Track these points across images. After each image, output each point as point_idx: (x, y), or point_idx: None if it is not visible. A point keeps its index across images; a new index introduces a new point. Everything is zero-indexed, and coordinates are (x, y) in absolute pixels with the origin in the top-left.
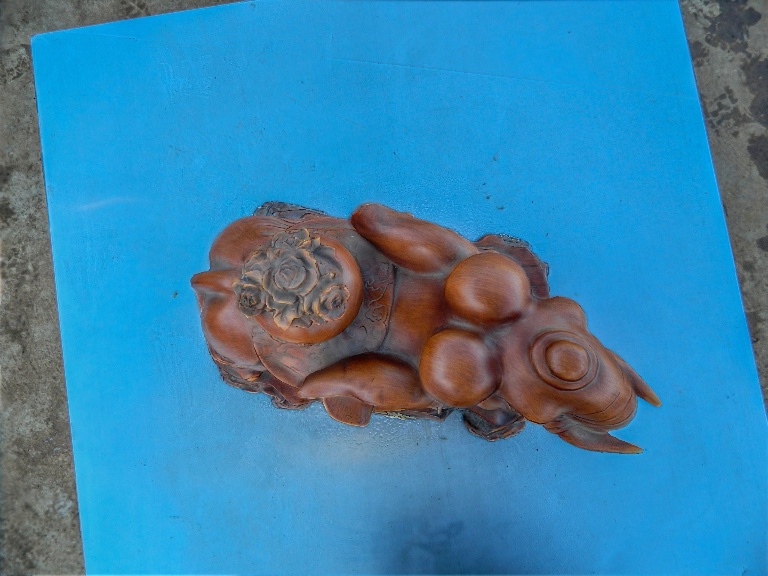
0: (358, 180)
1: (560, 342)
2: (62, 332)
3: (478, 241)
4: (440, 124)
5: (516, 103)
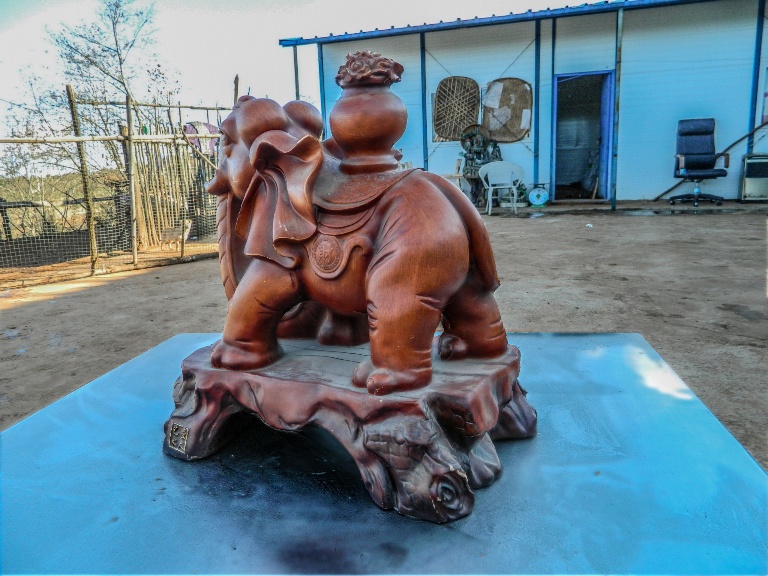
0: (307, 530)
1: (246, 100)
2: (763, 473)
3: (219, 385)
4: (142, 570)
5: (16, 573)
